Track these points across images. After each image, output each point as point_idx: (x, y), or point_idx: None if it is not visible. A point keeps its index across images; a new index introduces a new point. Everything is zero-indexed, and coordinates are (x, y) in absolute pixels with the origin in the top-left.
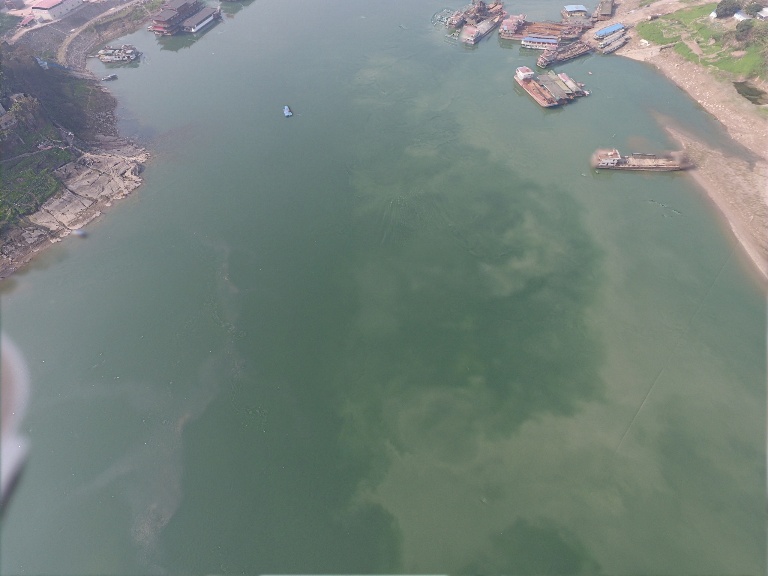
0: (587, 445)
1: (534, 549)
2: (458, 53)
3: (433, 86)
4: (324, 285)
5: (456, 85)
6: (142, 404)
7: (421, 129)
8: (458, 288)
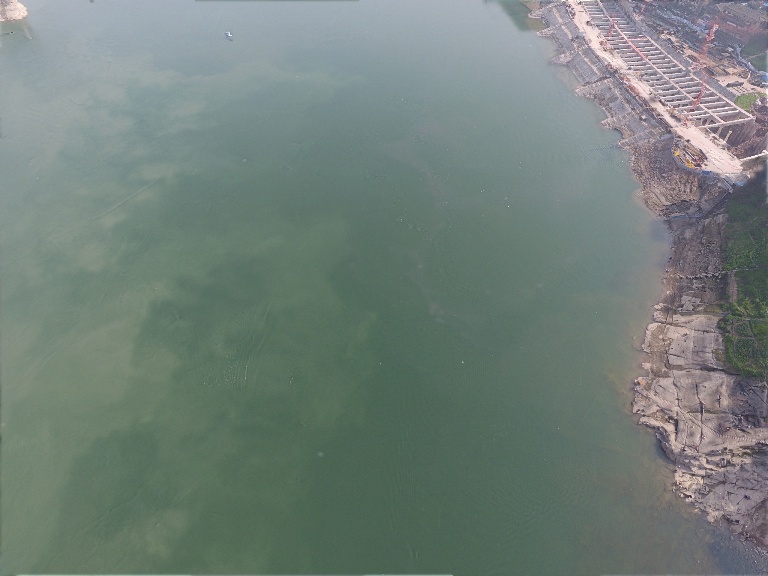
0: (174, 182)
1: (228, 141)
2: None
3: None
4: (334, 261)
5: None
6: (455, 181)
7: None
8: (209, 273)
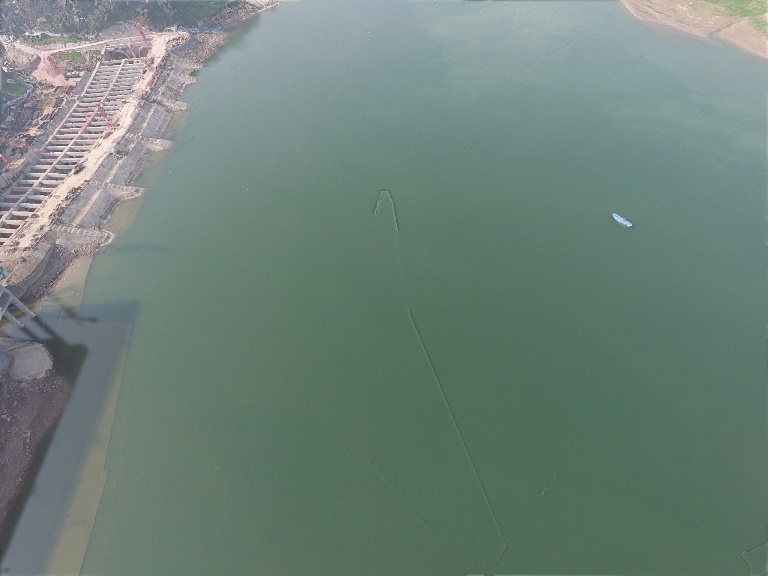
0: (533, 57)
1: None
2: None
3: None
4: (407, 20)
5: None
6: (329, 49)
7: None
8: (475, 23)
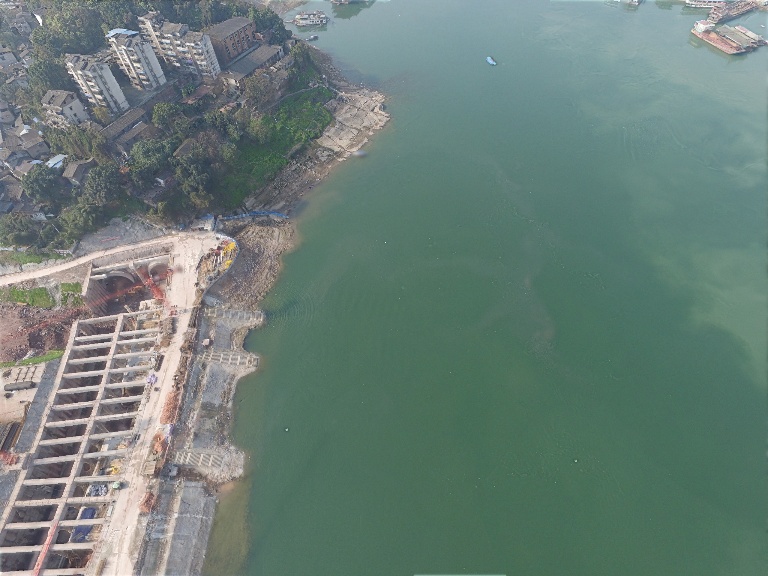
0: None
1: None
2: (623, 13)
3: (614, 40)
4: (596, 190)
5: (637, 38)
6: (485, 271)
7: (623, 73)
8: (712, 194)
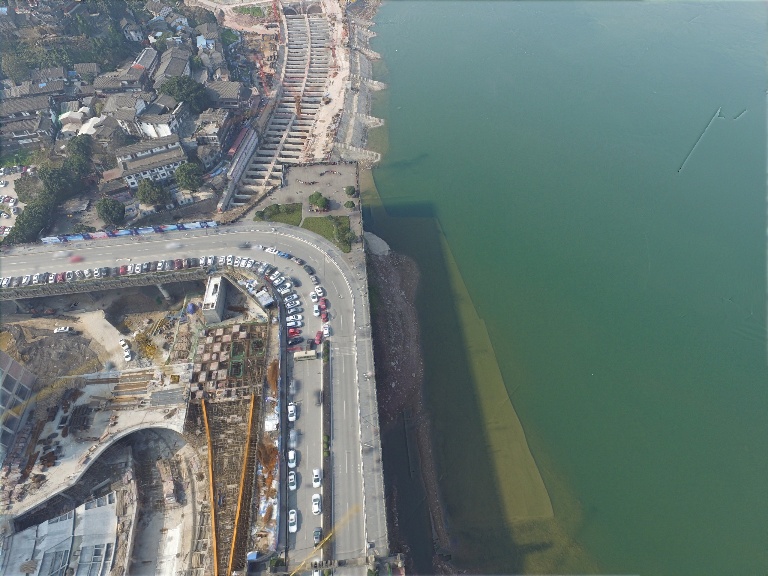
0: (673, 24)
1: None
2: None
3: None
4: None
5: None
6: (485, 12)
7: None
8: None
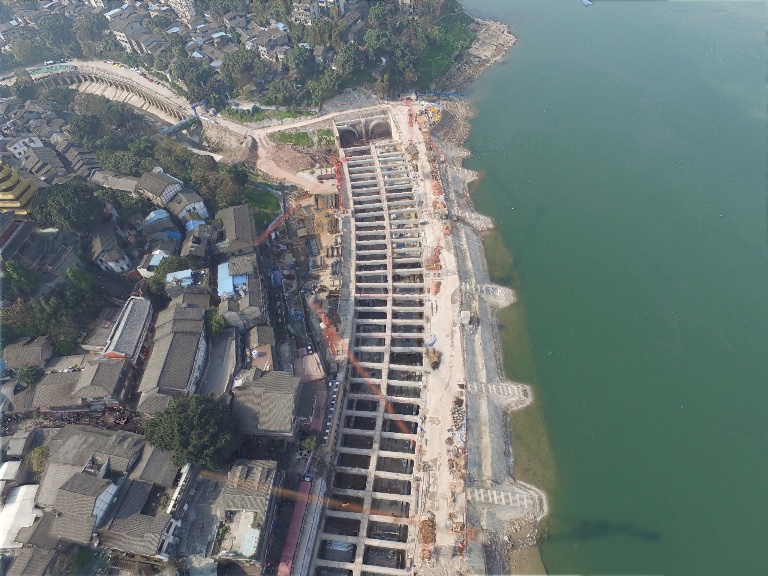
0: None
1: None
2: None
3: None
4: (697, 80)
5: None
6: (626, 126)
7: (699, 9)
8: None
